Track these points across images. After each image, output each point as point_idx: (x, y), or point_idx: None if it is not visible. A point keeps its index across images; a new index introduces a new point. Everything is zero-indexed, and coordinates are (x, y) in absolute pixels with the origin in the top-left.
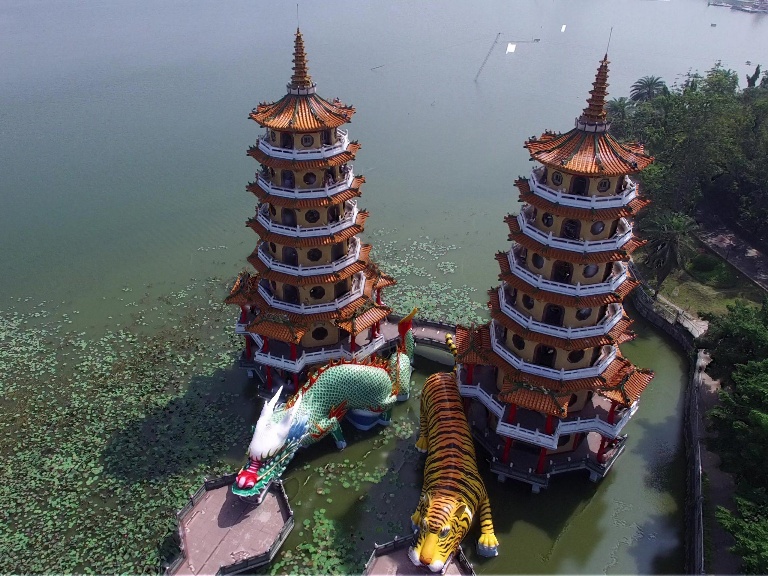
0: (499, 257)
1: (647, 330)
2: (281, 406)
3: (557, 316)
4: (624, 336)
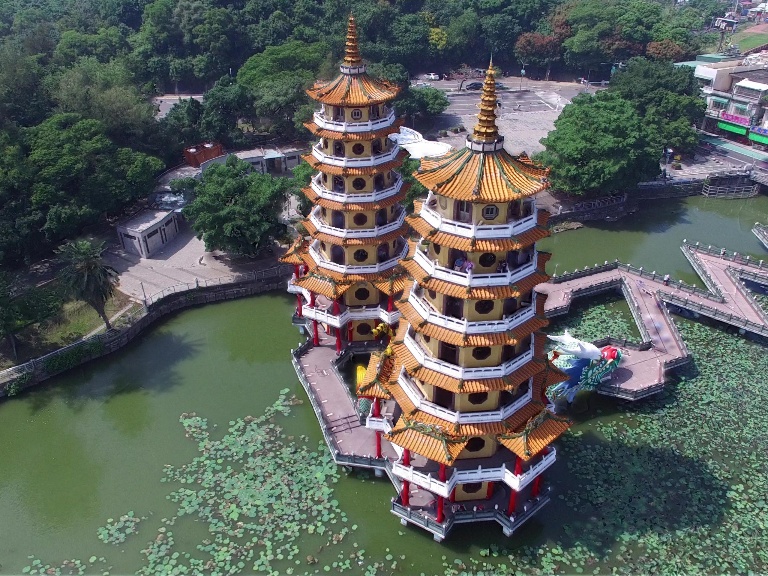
0: (381, 205)
1: (150, 338)
2: None
3: None
4: None
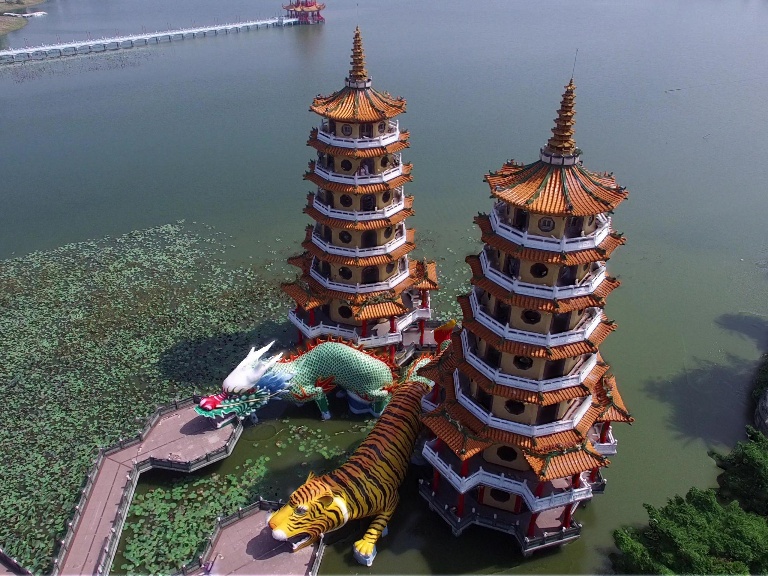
0: None
1: (747, 441)
2: None
3: (497, 356)
4: (616, 415)
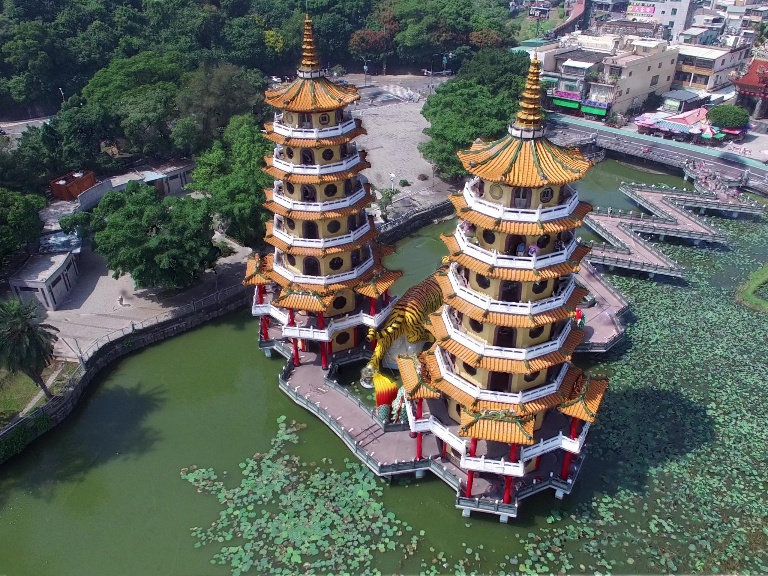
0: None
1: (96, 397)
2: None
3: None
4: None
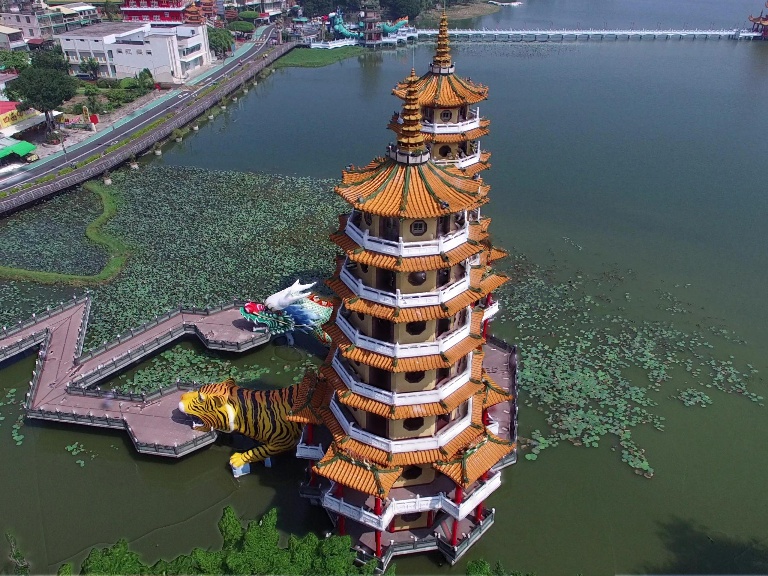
0: None
1: None
2: (318, 299)
3: None
4: (457, 473)
